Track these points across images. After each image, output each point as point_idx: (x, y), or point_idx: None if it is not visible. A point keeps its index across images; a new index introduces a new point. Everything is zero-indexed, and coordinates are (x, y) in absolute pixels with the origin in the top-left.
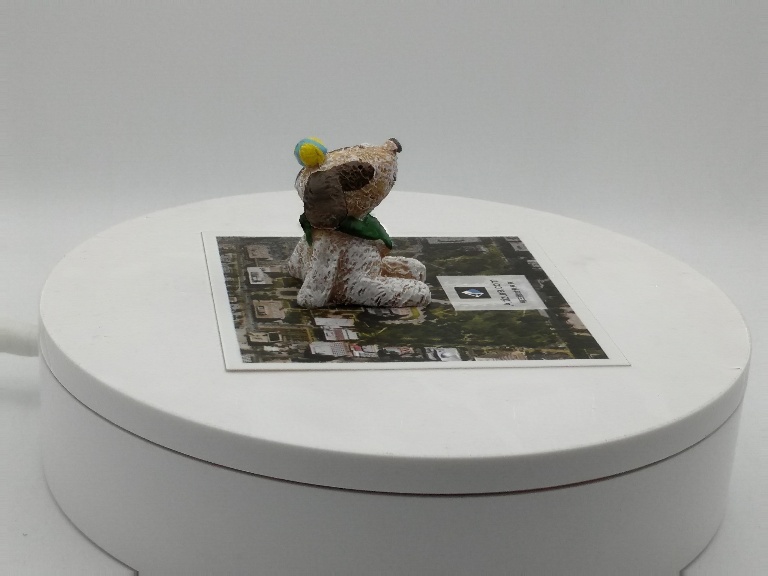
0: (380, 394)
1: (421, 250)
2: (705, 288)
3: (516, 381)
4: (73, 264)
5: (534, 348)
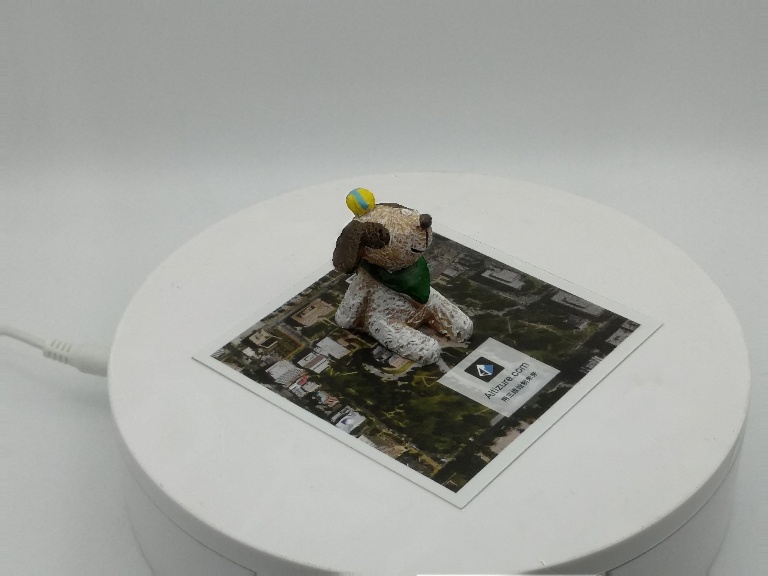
0: (245, 432)
1: (529, 303)
2: (695, 466)
3: (351, 473)
4: (271, 206)
5: (420, 450)
